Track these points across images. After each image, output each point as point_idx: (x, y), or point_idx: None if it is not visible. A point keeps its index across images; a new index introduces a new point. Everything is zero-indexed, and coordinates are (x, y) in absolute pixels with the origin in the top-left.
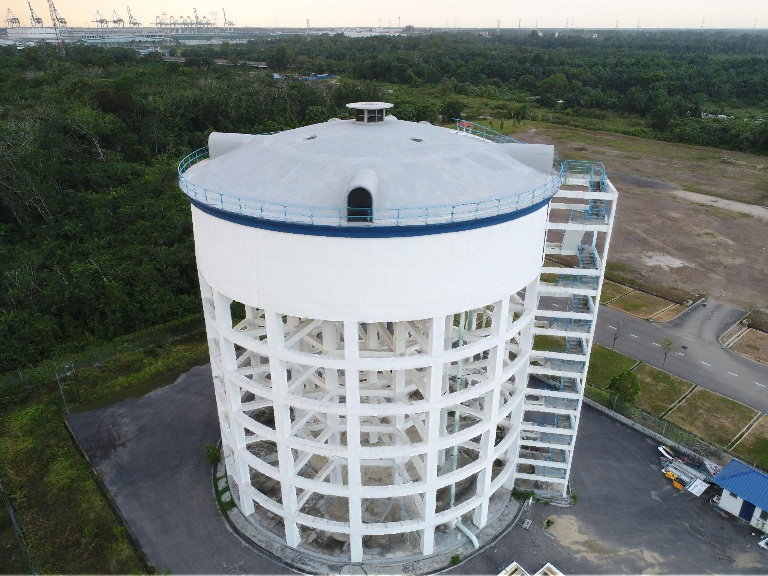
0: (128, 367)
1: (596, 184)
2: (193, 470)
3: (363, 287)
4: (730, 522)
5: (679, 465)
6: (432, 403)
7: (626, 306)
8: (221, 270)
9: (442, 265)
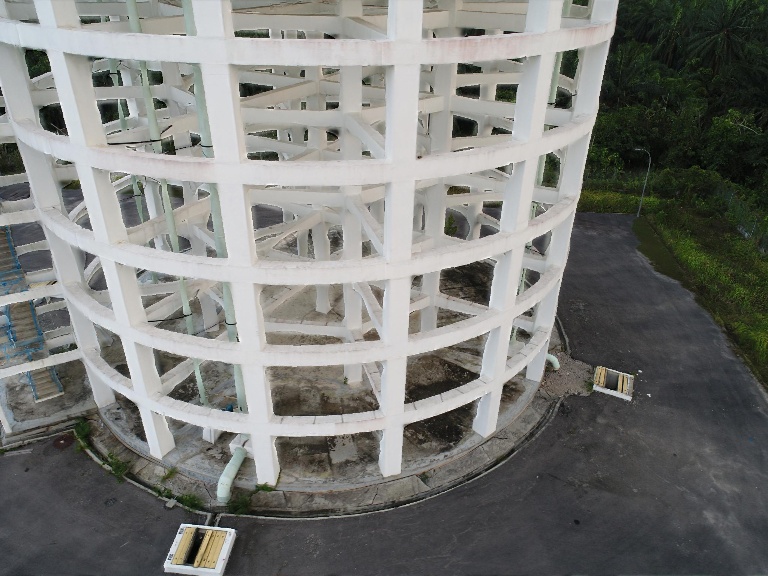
0: None
1: None
2: None
3: None
4: None
5: None
6: None
7: None
8: None
9: None
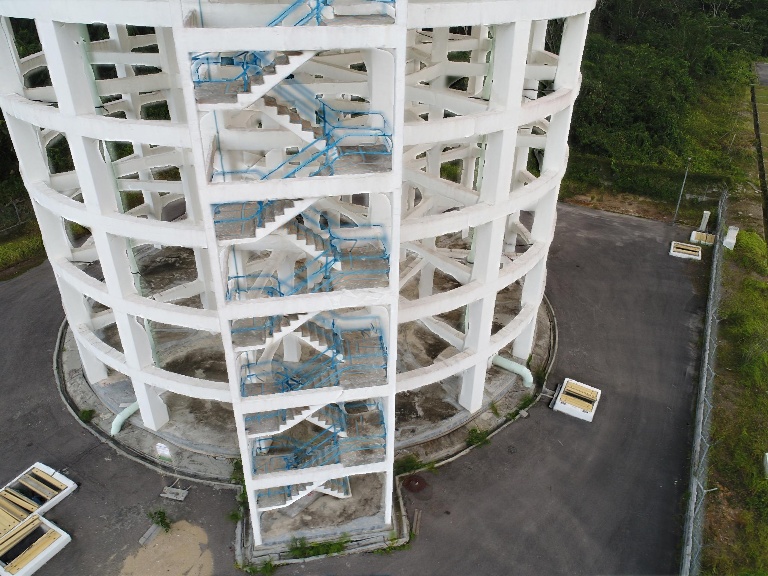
0: None
1: None
2: None
3: None
4: None
5: None
6: None
7: None
8: None
9: None
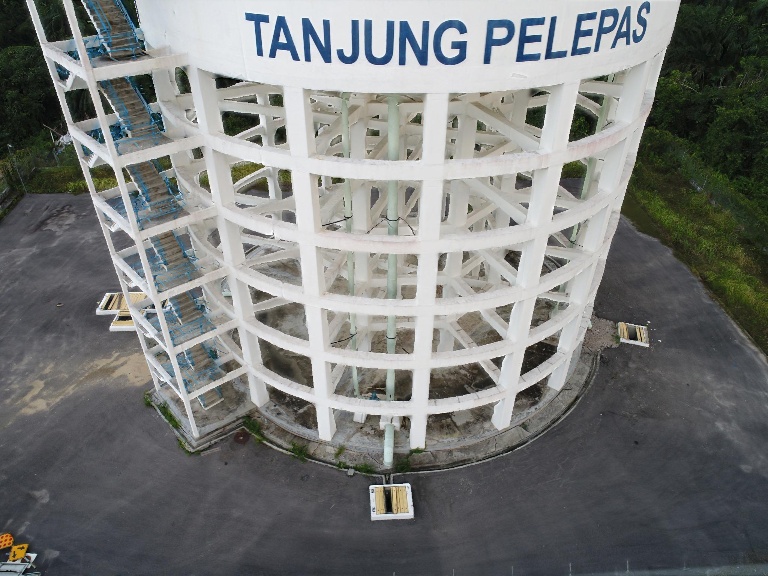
0: None
1: None
2: None
3: None
4: None
5: None
6: None
7: None
8: None
9: None
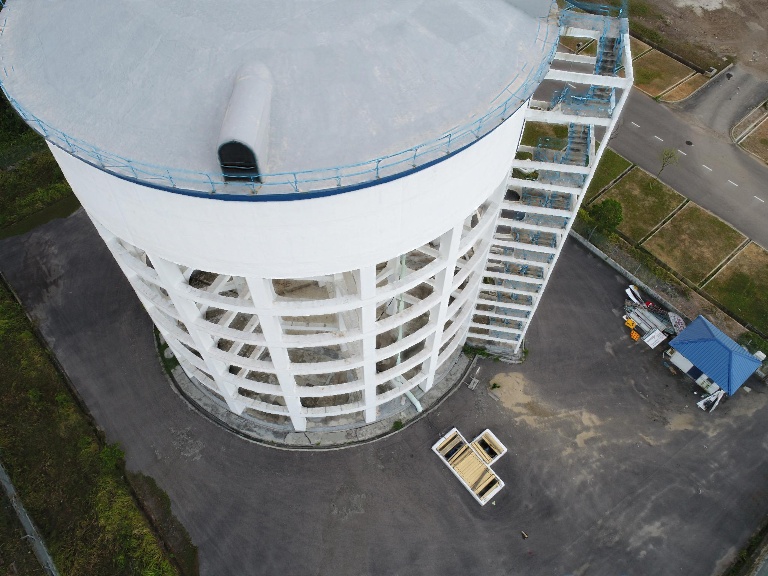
0: (48, 170)
1: (609, 42)
2: (132, 318)
3: (262, 248)
4: (676, 379)
5: (642, 312)
6: (365, 333)
7: (636, 77)
8: (79, 192)
9: (368, 218)
